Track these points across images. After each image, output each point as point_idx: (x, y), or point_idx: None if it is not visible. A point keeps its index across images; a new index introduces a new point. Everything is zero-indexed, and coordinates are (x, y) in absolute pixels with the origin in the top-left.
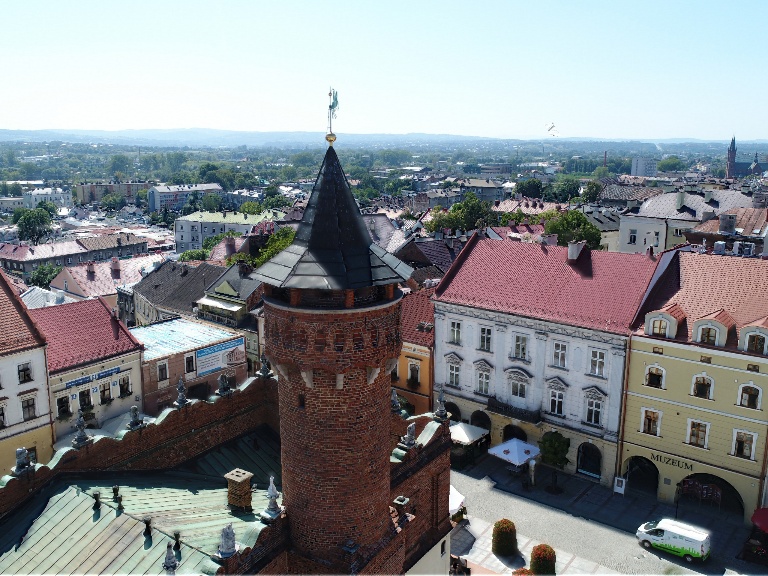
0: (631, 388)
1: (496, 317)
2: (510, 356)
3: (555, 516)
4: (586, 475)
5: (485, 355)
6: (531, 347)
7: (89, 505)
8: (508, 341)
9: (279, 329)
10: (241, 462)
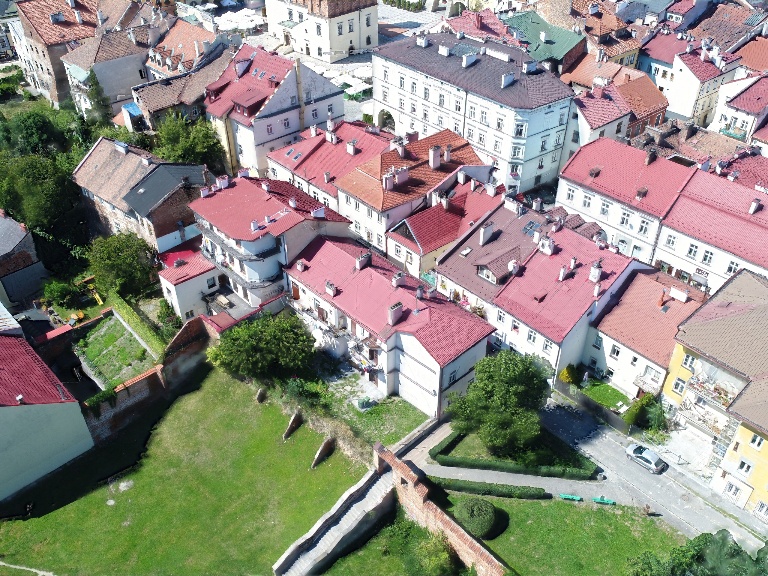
0: None
1: None
2: None
3: (256, 10)
4: (240, 4)
5: None
6: None
7: None
8: None
9: None
10: None
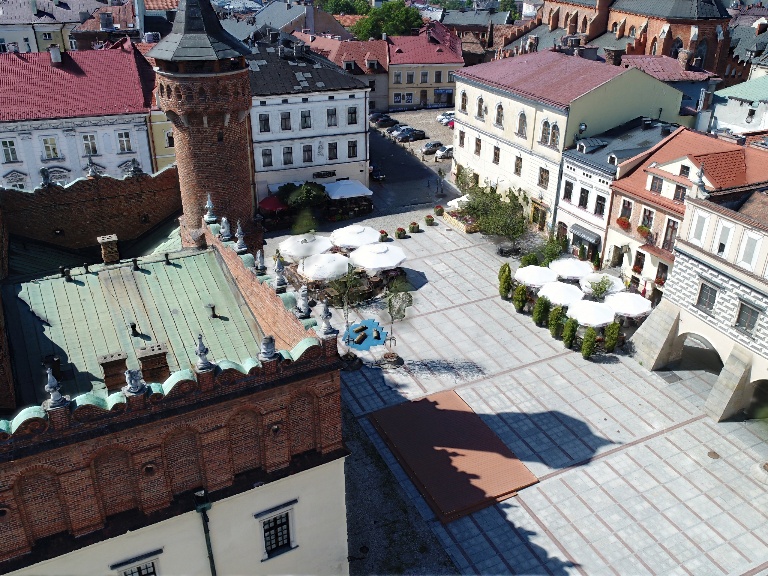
0: (158, 153)
1: (18, 127)
2: (43, 159)
3: None
4: None
5: (14, 166)
6: (62, 145)
7: (62, 282)
8: (36, 146)
9: (207, 91)
10: (33, 260)
